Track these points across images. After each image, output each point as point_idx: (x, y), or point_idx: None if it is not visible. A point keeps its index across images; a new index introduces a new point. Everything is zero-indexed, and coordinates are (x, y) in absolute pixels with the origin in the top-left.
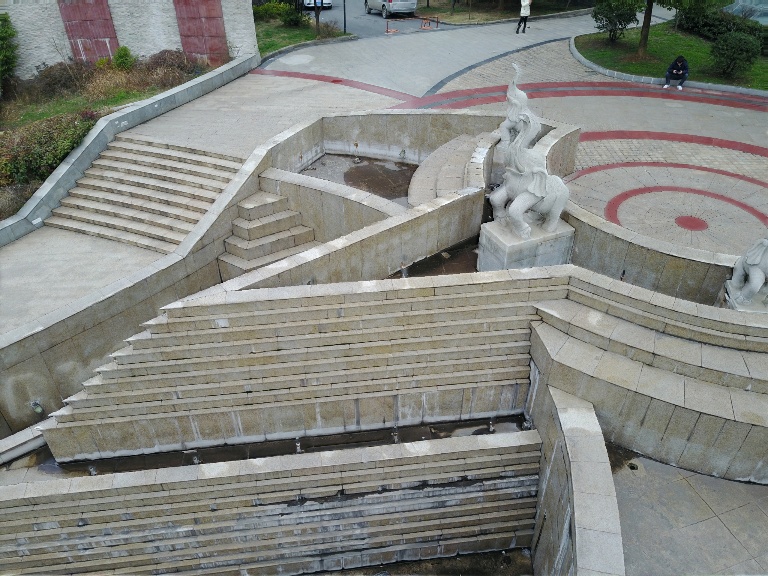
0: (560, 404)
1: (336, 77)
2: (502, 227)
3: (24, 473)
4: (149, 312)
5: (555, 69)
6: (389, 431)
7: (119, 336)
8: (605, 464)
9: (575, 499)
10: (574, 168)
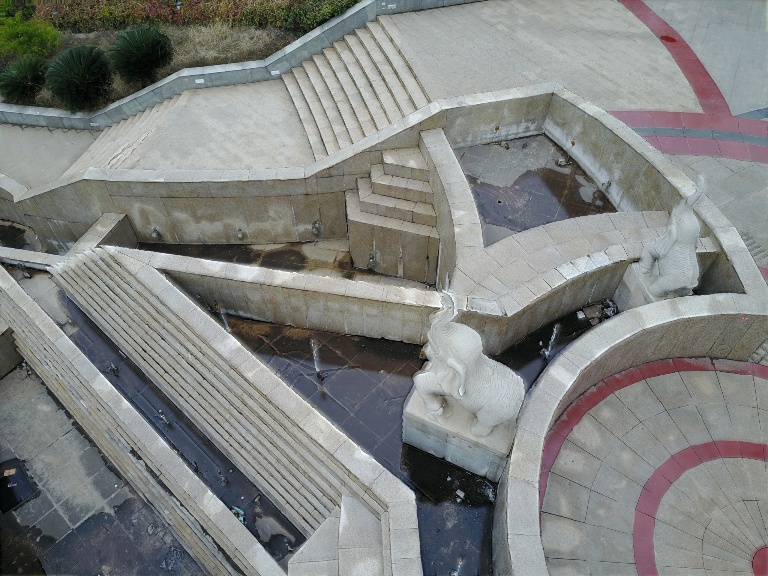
0: None
1: (676, 32)
2: None
3: (50, 288)
4: (261, 208)
5: None
6: (232, 466)
7: (230, 214)
8: None
9: None
10: (758, 356)
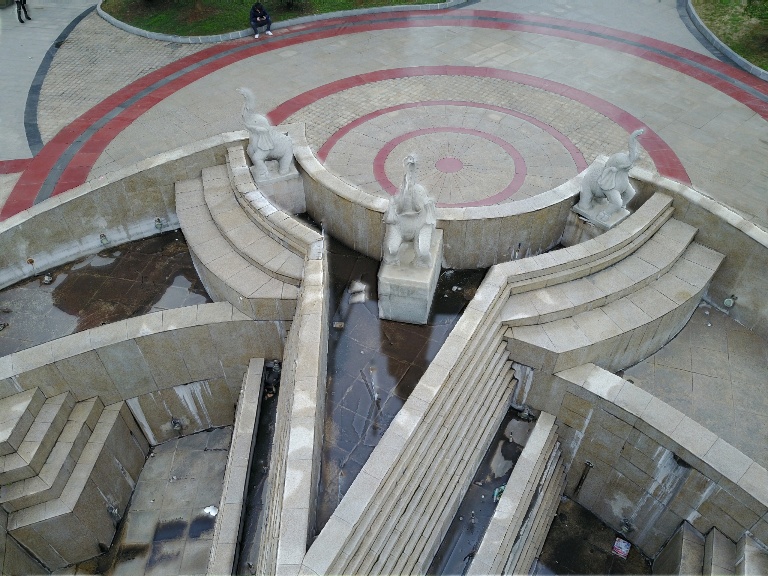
0: (579, 382)
1: None
2: (399, 268)
3: None
4: None
5: (132, 55)
6: (456, 519)
7: None
8: (654, 399)
9: (677, 441)
10: None
